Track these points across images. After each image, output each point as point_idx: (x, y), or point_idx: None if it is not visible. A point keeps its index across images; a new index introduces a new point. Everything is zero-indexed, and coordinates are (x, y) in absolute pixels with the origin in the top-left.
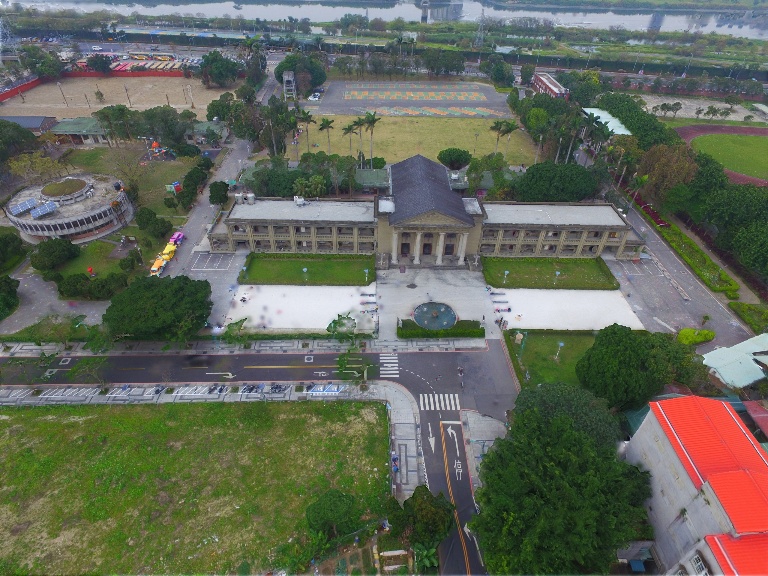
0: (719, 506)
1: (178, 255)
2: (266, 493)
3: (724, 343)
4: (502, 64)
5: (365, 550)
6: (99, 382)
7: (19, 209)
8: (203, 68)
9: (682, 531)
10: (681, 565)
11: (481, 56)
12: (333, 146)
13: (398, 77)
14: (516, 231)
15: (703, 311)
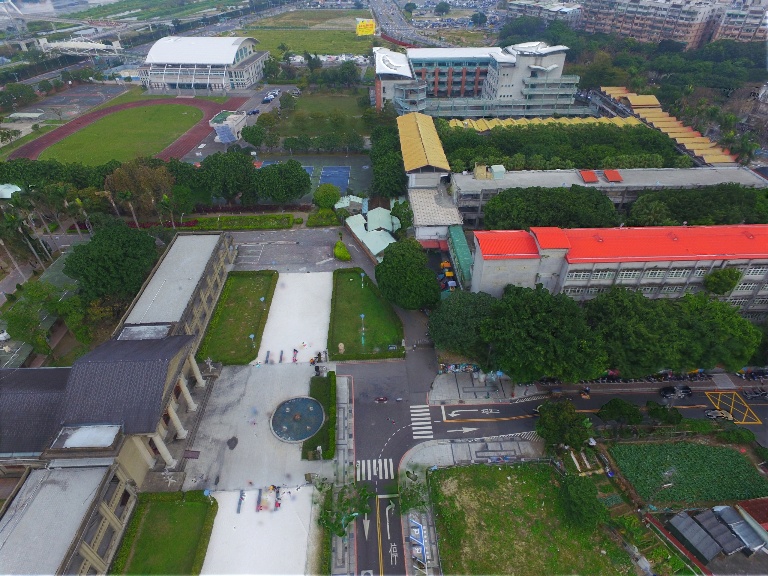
0: (555, 251)
1: None
2: None
3: (346, 241)
4: None
5: None
6: None
7: None
8: None
9: (542, 282)
10: (564, 287)
11: None
12: None
13: None
14: None
15: (312, 239)
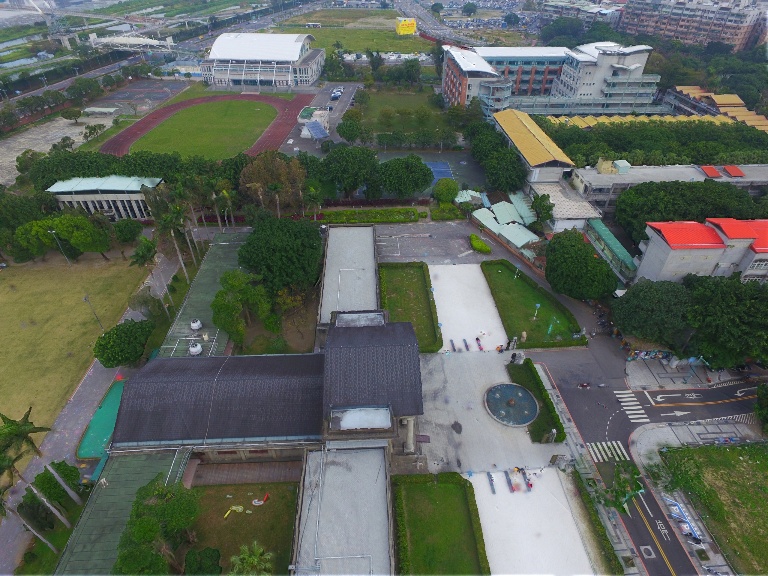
0: None
1: None
2: None
3: (478, 234)
4: None
5: None
6: None
7: None
8: None
9: None
10: None
11: None
12: None
13: None
14: None
15: (443, 232)
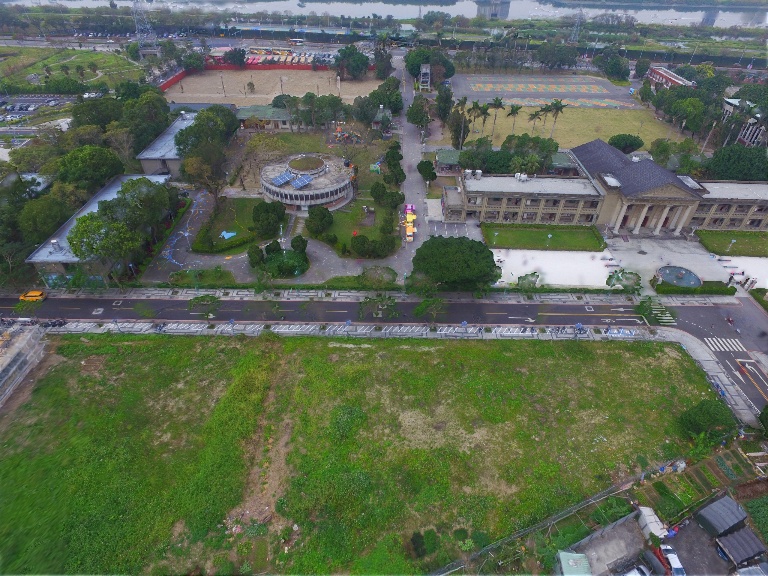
0: None
1: (416, 224)
2: (624, 407)
3: None
4: (617, 58)
5: (733, 451)
6: (423, 322)
7: (280, 181)
8: (340, 61)
9: None
10: None
11: (584, 51)
12: (493, 133)
13: (513, 71)
14: (727, 206)
15: None
